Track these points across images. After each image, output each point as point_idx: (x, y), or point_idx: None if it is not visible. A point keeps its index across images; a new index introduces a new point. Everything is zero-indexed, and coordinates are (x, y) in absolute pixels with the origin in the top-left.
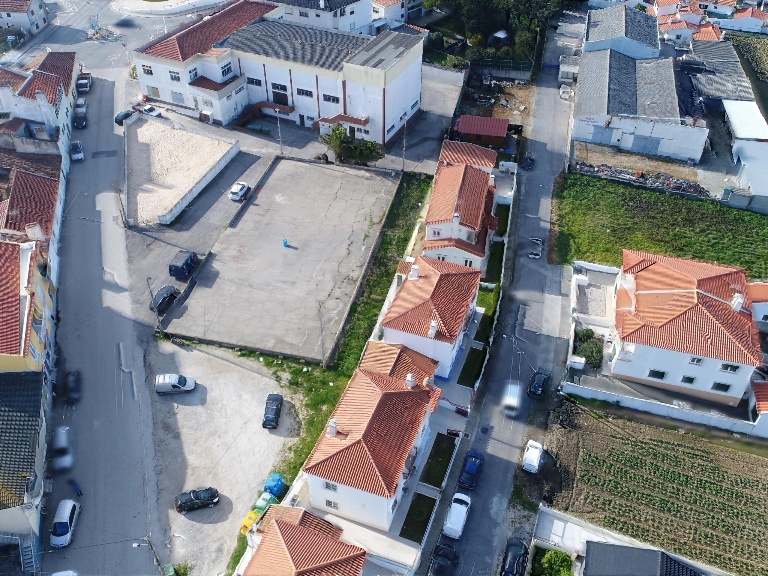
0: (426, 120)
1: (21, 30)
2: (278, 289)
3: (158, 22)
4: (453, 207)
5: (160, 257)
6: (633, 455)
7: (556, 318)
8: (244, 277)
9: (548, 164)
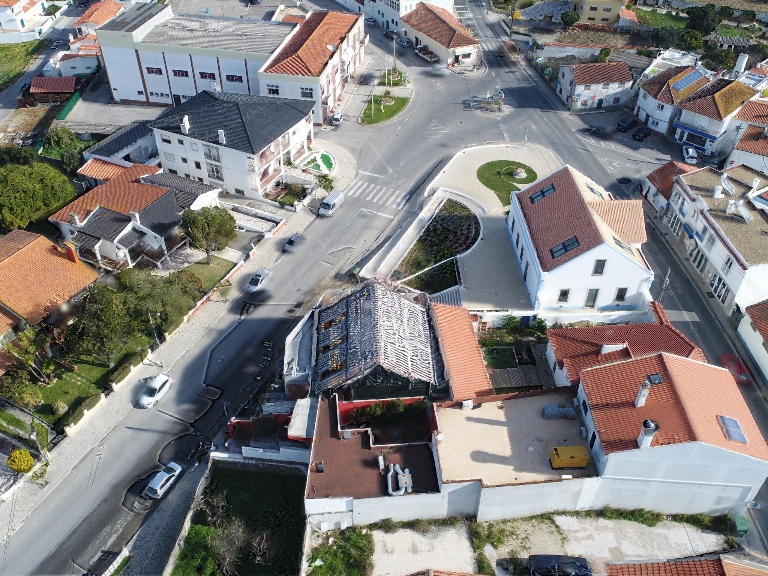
0: (111, 96)
1: (552, 71)
2: (207, 0)
3: (456, 138)
4: (105, 3)
5: (274, 2)
6: (55, 0)
7: (63, 21)
8: (226, 2)
9: (11, 93)
